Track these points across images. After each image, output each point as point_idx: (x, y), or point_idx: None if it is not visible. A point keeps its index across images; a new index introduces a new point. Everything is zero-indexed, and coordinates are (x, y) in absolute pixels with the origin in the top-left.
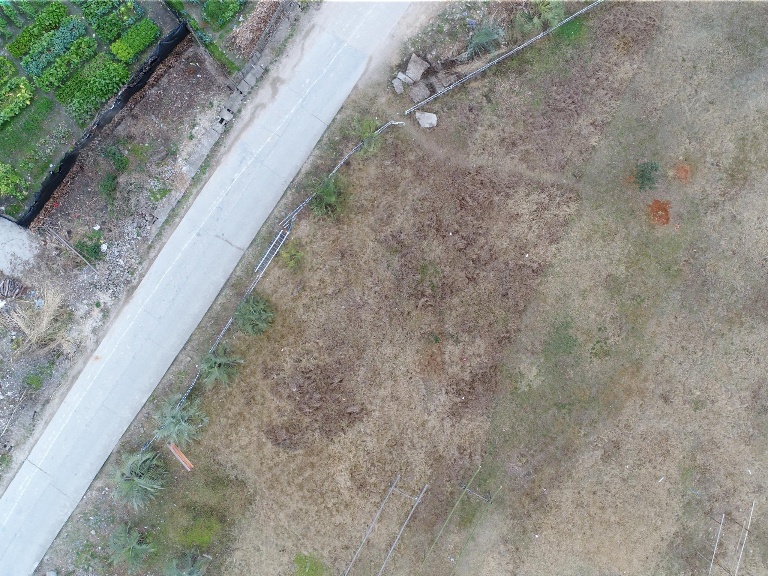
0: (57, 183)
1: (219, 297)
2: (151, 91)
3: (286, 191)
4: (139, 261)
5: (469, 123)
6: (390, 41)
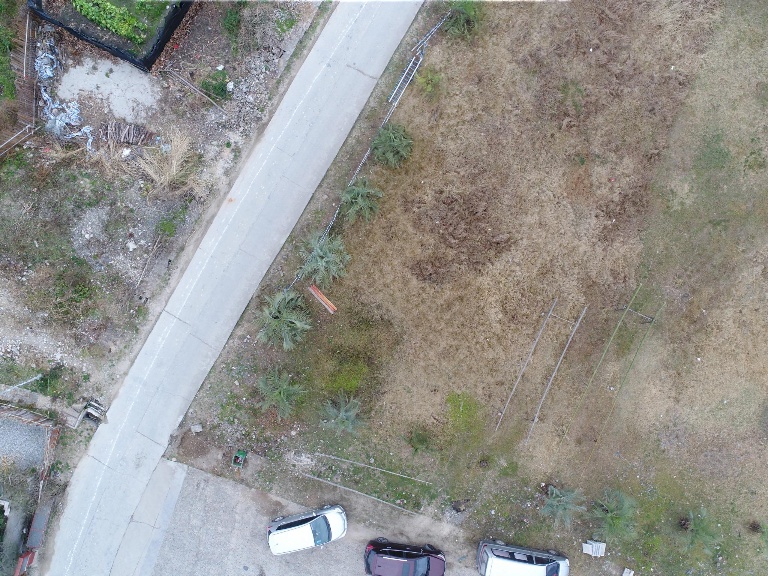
0: (177, 22)
1: (353, 130)
2: None
3: (417, 15)
4: (268, 97)
5: None
6: None
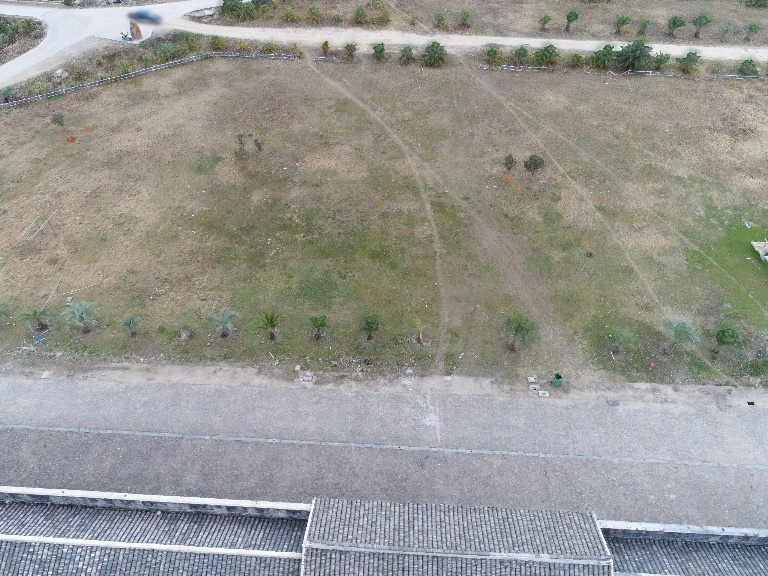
0: None
1: None
2: None
3: None
4: None
5: None
6: None
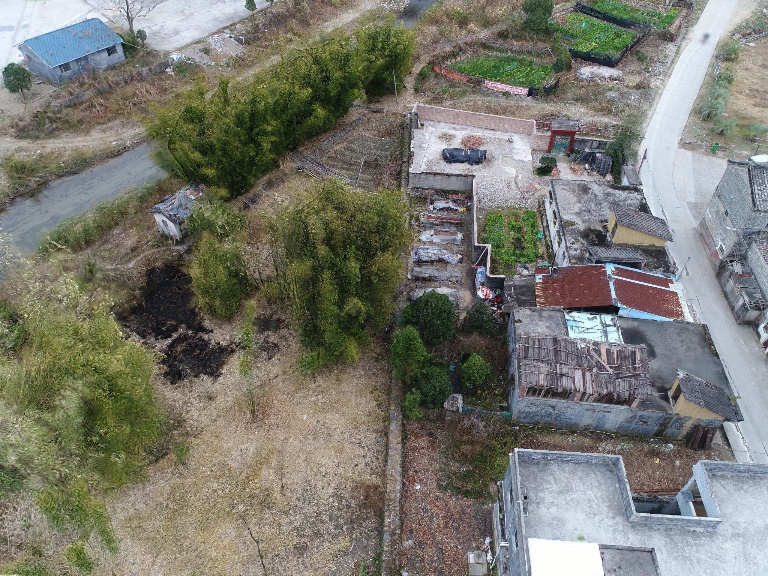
0: None
1: (705, 77)
2: None
3: (712, 57)
4: None
5: (767, 45)
6: (724, 31)
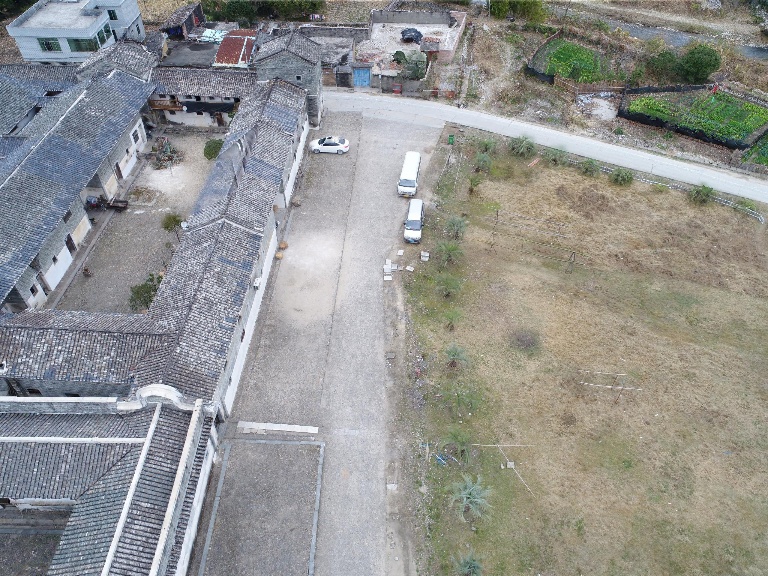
0: (643, 122)
1: (622, 168)
2: (706, 145)
3: (692, 185)
4: (624, 144)
5: None
6: None
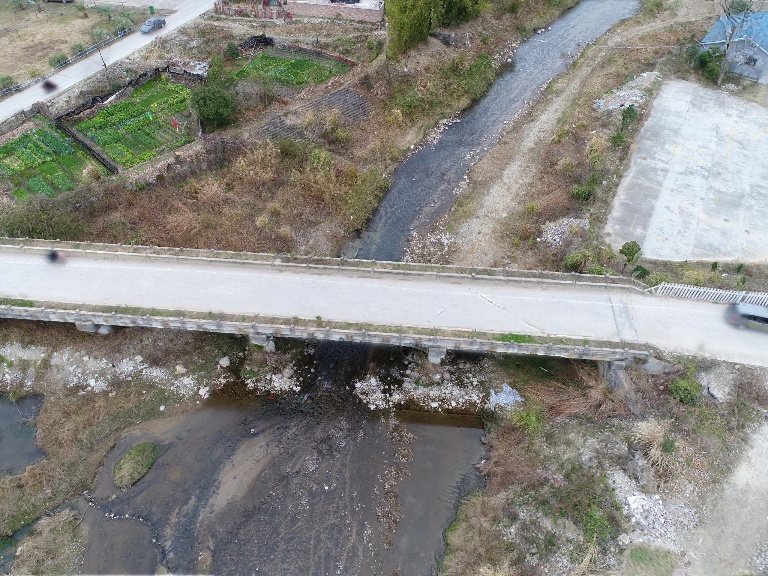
0: None
1: None
2: None
3: None
4: None
5: None
6: None
